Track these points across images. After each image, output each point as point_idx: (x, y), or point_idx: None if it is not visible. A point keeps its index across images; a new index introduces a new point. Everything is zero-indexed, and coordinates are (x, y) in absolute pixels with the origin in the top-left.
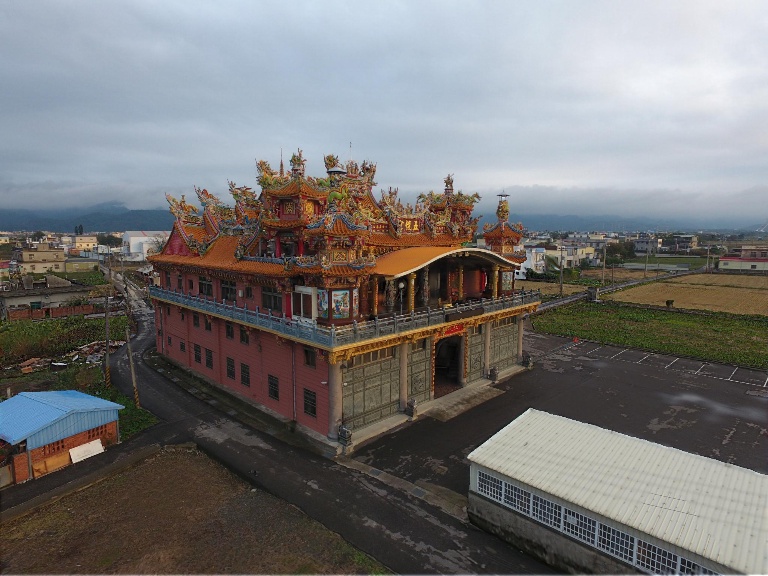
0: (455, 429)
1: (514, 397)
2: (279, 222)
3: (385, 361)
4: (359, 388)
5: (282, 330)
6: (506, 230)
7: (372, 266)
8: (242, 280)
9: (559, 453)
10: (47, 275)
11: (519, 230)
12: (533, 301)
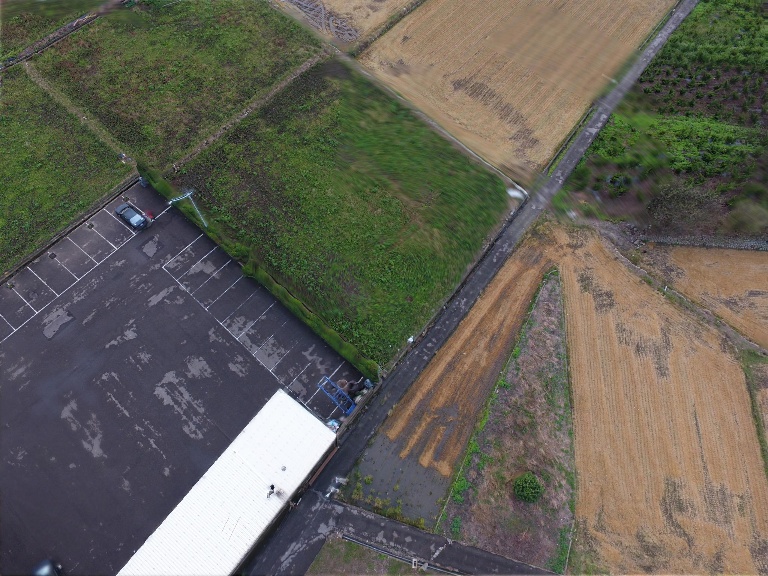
0: None
1: (12, 562)
2: None
3: None
4: None
5: None
6: None
7: None
8: None
9: (178, 574)
10: None
11: None
12: None
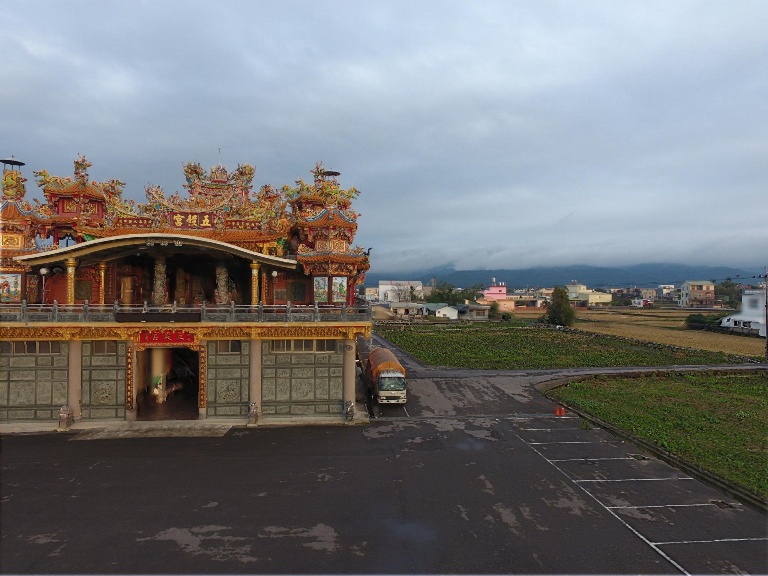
0: (45, 448)
1: (203, 442)
2: None
3: (44, 356)
4: (0, 377)
5: None
6: (320, 219)
7: (30, 251)
8: None
9: None
10: None
11: None
12: (350, 320)
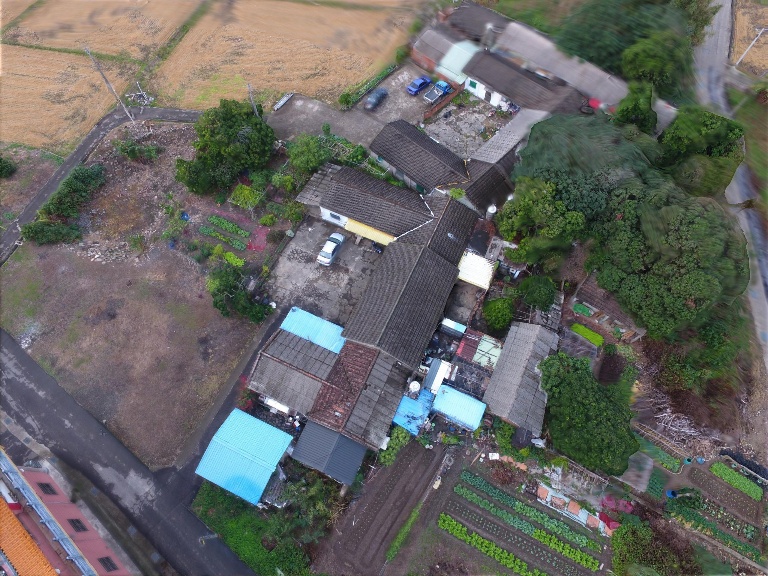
0: None
1: None
2: None
3: None
4: None
5: (28, 487)
6: None
7: None
8: None
9: None
10: None
11: None
12: None
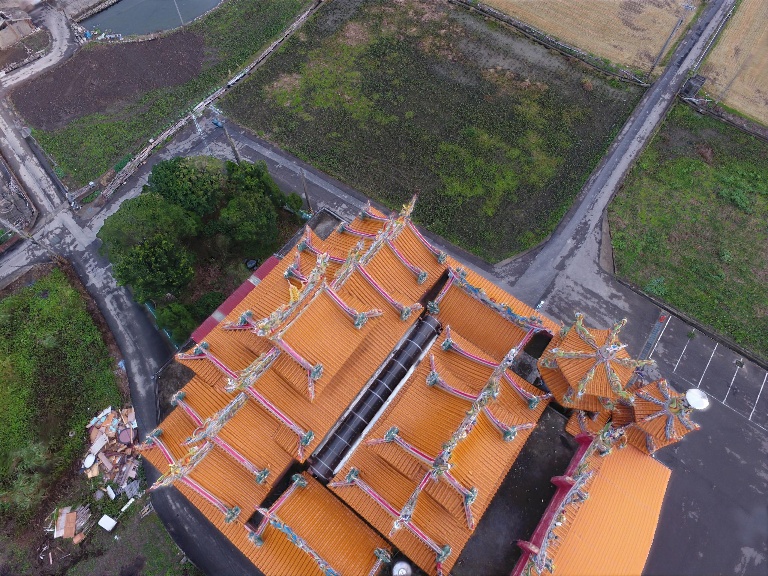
0: None
1: None
2: None
3: None
4: None
5: None
6: None
7: None
8: None
9: None
10: None
11: (691, 428)
12: None
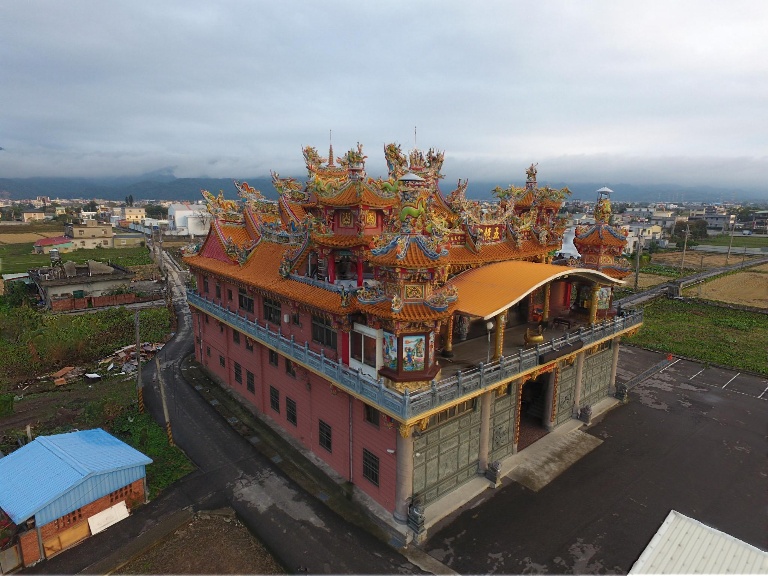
0: (552, 507)
1: (617, 451)
2: (334, 238)
3: (464, 417)
4: (433, 454)
5: (338, 379)
6: (606, 236)
7: (453, 301)
8: (288, 304)
9: None
10: (89, 261)
11: (623, 236)
12: (635, 323)
